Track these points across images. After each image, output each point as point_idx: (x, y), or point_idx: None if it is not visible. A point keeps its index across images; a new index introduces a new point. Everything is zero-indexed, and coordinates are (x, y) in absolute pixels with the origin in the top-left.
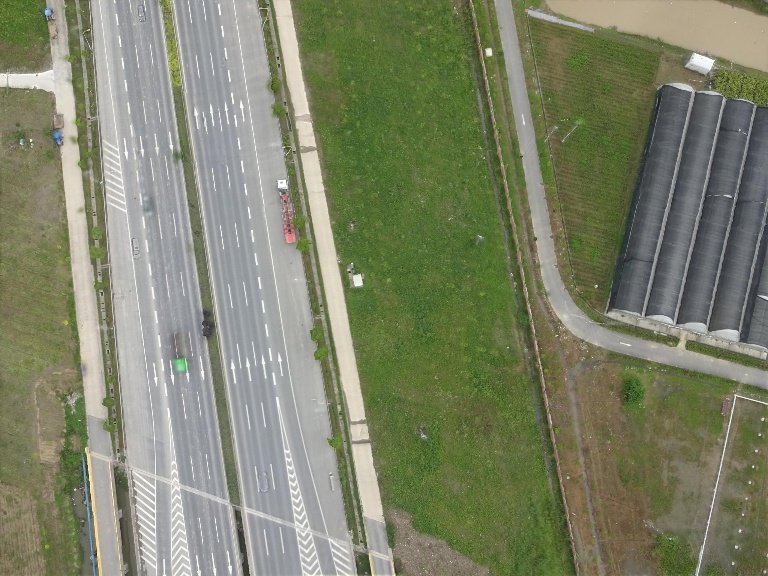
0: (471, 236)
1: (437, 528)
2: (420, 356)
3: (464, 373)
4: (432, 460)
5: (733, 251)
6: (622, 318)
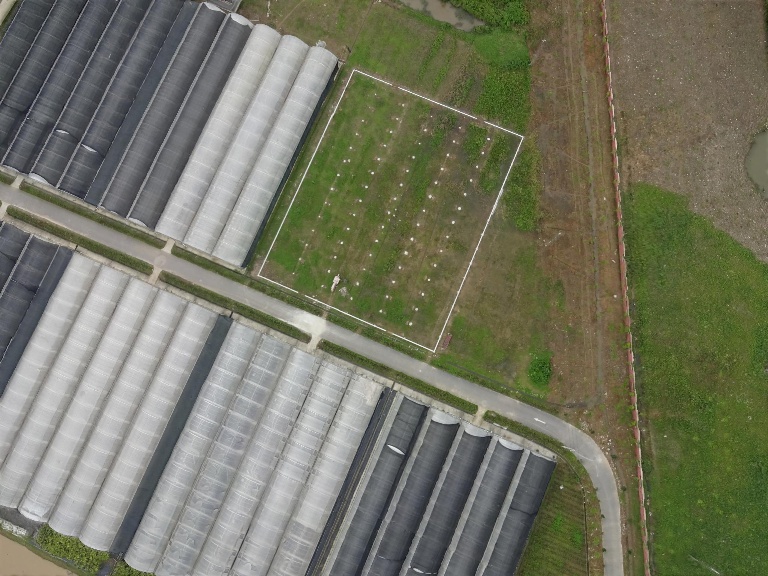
0: (697, 566)
1: (764, 271)
2: (765, 443)
3: (720, 418)
4: (763, 336)
5: (422, 507)
6: (538, 449)
